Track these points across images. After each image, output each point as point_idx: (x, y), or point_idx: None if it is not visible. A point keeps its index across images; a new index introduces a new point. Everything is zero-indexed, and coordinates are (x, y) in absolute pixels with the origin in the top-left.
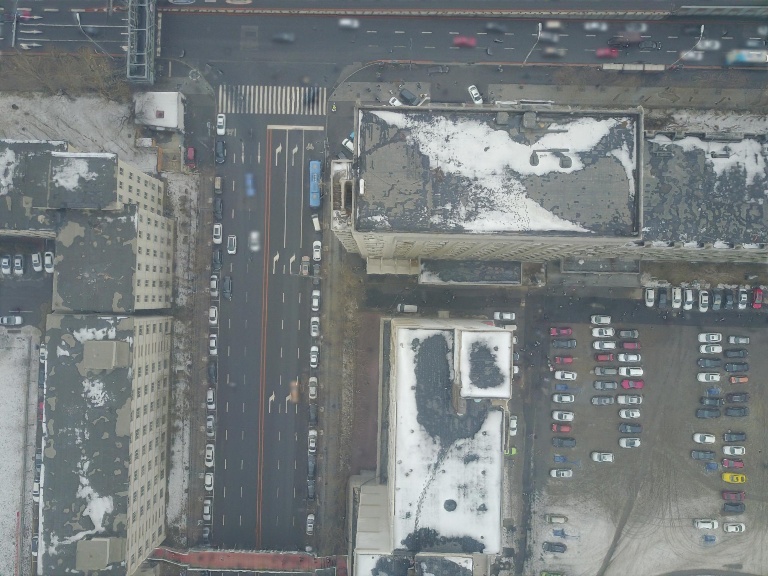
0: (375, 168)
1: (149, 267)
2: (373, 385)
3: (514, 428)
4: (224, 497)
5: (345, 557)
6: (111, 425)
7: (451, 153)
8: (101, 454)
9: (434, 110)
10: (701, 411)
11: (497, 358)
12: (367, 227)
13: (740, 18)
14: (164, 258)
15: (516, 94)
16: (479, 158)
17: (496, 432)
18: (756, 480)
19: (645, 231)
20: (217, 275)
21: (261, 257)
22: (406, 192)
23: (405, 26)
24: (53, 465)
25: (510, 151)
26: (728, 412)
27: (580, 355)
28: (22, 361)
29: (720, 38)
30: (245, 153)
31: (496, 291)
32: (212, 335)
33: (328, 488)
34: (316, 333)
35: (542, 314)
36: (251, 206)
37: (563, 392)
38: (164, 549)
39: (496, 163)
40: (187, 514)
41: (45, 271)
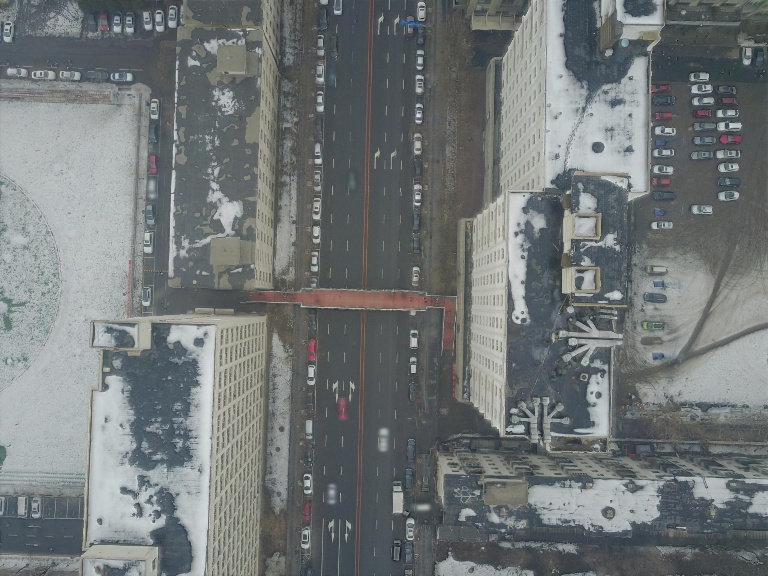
0: None
1: (268, 2)
2: (476, 141)
3: None
4: (330, 250)
5: (453, 299)
6: (241, 132)
7: None
8: (231, 160)
9: None
10: None
11: None
12: None
13: None
14: (276, 9)
15: None
16: None
17: (642, 77)
18: None
19: None
20: (323, 35)
21: (366, 19)
22: None
23: None
24: (184, 171)
25: None
26: None
27: (679, 113)
28: (133, 117)
29: None
30: None
31: None
32: (319, 92)
33: (433, 241)
34: (421, 89)
35: None
36: None
37: (663, 148)
38: (275, 293)
39: None
40: (295, 266)
41: (155, 30)
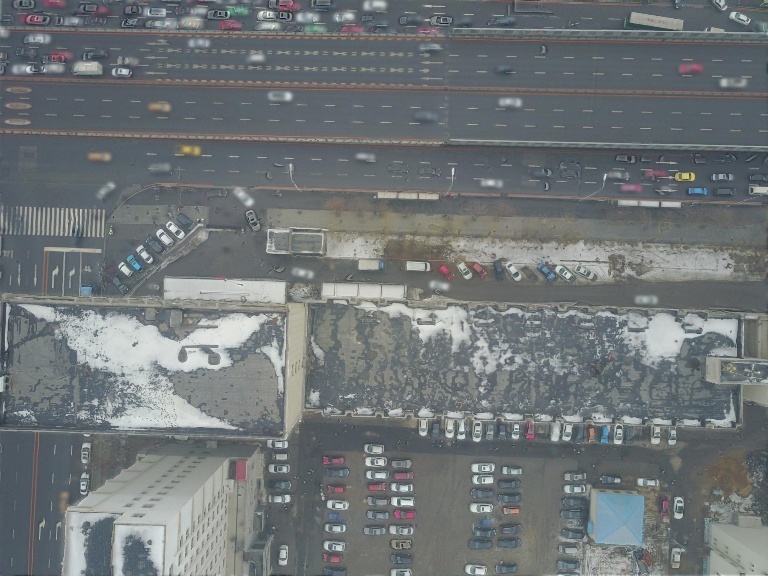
0: (22, 362)
1: None
2: None
3: (284, 558)
4: None
5: None
6: None
7: (99, 348)
8: None
9: (81, 305)
10: (472, 542)
11: (151, 552)
12: (13, 422)
13: (517, 147)
14: None
15: (295, 219)
16: (127, 353)
17: None
18: None
19: (350, 398)
20: None
21: None
22: (52, 387)
23: (185, 149)
24: None
25: (159, 347)
26: (499, 544)
27: (354, 483)
28: None
29: (499, 165)
30: (22, 275)
31: None
32: None
33: None
34: (86, 460)
35: (316, 442)
36: None
37: (335, 521)
38: None
39: (144, 359)
40: None
41: None
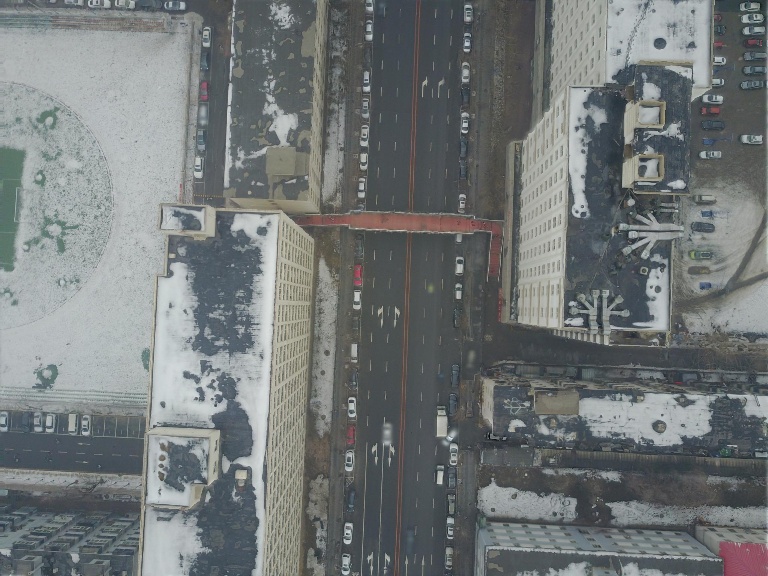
0: None
1: None
2: (524, 70)
3: None
4: (377, 177)
5: (500, 224)
6: (297, 46)
7: None
8: (287, 74)
9: None
10: None
11: None
12: None
13: None
14: None
15: None
16: None
17: None
18: None
19: None
20: None
21: None
22: None
23: None
24: (241, 84)
25: None
26: None
27: (729, 43)
28: (185, 45)
29: None
30: None
31: None
32: (368, 21)
33: (479, 169)
34: (470, 18)
35: None
36: None
37: None
38: (323, 216)
39: None
40: (342, 192)
41: None
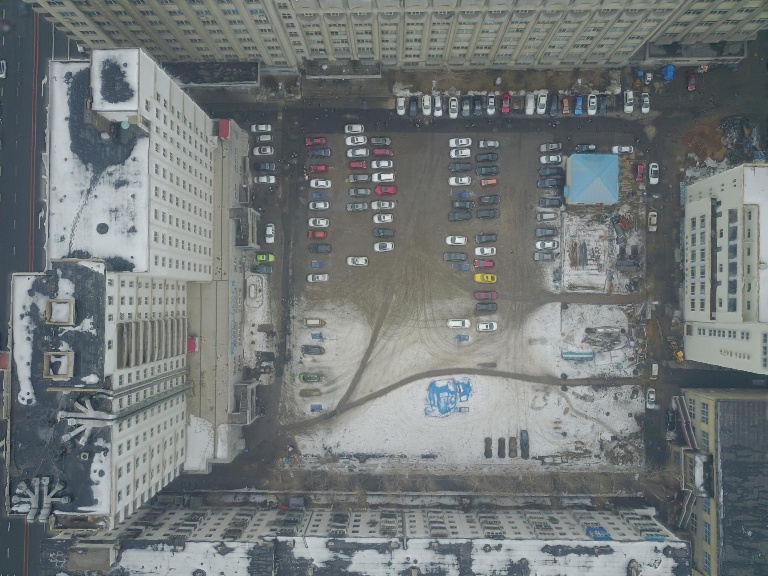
0: None
1: None
2: None
3: (270, 235)
4: None
5: None
6: None
7: None
8: None
9: None
10: (452, 214)
11: (126, 74)
12: None
13: None
14: None
15: None
16: None
17: (144, 157)
18: (508, 280)
19: None
20: None
21: (30, 81)
22: None
23: None
24: None
25: None
26: (478, 214)
27: (336, 164)
28: None
29: None
30: None
31: (253, 105)
32: None
33: None
34: None
35: (298, 126)
36: (21, 33)
37: (319, 200)
38: None
39: None
40: None
41: None
